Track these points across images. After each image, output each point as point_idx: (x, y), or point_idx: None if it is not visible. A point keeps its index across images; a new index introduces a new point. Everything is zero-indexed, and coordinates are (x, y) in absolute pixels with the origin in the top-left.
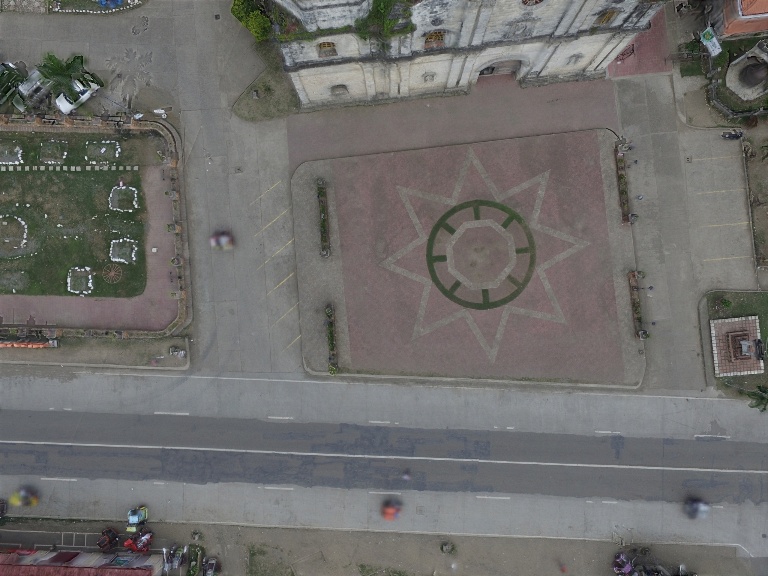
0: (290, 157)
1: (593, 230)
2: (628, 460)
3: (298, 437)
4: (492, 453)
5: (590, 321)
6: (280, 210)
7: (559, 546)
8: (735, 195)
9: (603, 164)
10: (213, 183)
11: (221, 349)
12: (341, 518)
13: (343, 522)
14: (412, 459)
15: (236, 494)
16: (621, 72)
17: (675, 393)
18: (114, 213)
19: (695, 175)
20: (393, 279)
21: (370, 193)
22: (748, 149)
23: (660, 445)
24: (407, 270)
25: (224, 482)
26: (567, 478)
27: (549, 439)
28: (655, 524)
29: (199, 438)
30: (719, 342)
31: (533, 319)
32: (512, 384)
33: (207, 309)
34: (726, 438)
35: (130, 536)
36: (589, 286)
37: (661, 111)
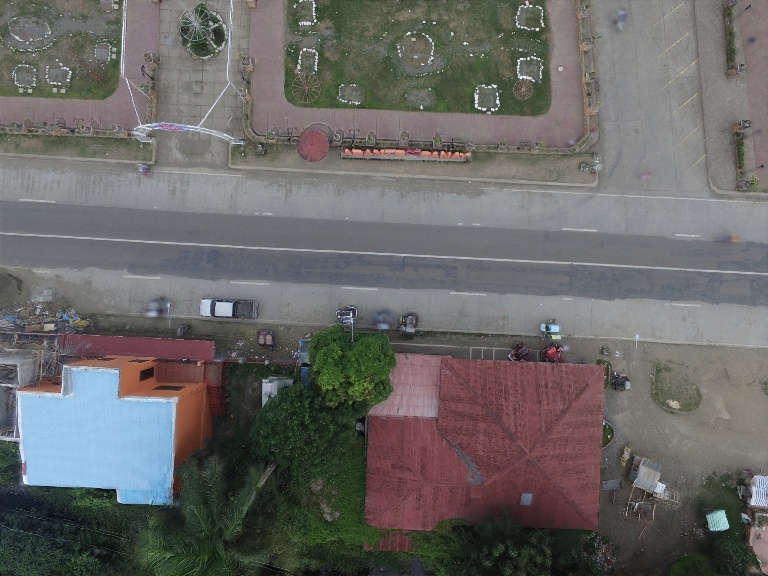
0: None
1: None
2: None
3: (705, 254)
4: None
5: None
6: (684, 31)
7: None
8: None
9: None
10: (616, 4)
11: (627, 167)
12: (747, 335)
13: (749, 339)
14: None
15: (644, 310)
16: None
17: None
18: (520, 32)
19: None
20: None
21: None
22: None
23: None
24: None
25: (632, 298)
26: None
27: None
28: None
29: (607, 254)
30: None
31: None
32: None
33: (612, 128)
34: None
35: (541, 350)
36: None
37: None
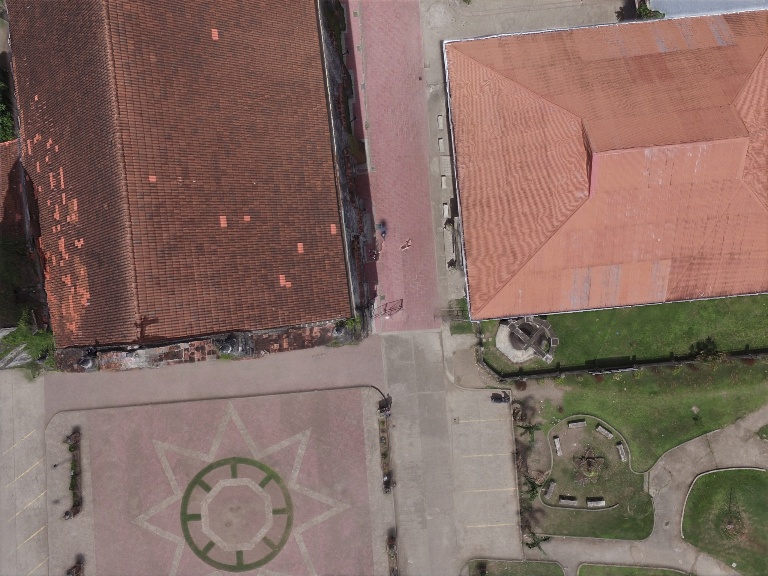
0: (46, 405)
1: (353, 493)
2: None
3: None
4: None
5: None
6: (33, 460)
7: None
8: (502, 459)
9: (366, 424)
10: None
11: None
12: None
13: None
14: None
15: None
16: (389, 327)
17: None
18: None
19: (462, 437)
20: (145, 537)
21: (125, 446)
22: (518, 411)
23: None
24: (160, 528)
25: None
26: None
27: None
28: None
29: None
30: None
31: None
32: None
33: None
34: None
35: None
36: (347, 551)
37: (429, 369)
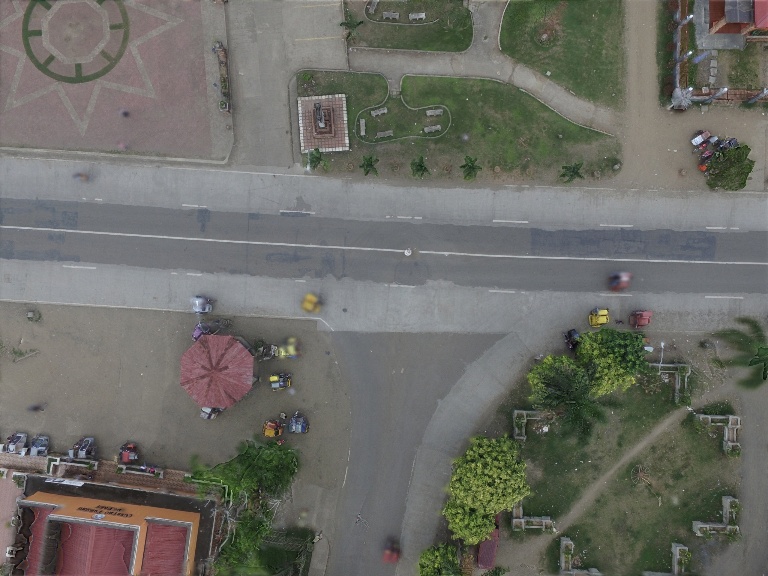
0: None
1: (186, 8)
2: (213, 233)
3: None
4: (79, 223)
5: (180, 96)
6: None
7: (144, 317)
8: None
9: None
10: None
11: None
12: None
13: None
14: (1, 228)
15: None
16: None
17: (263, 169)
18: None
19: None
20: None
21: None
22: None
23: (245, 219)
24: (2, 44)
25: None
26: (153, 250)
27: (136, 211)
28: (238, 297)
29: None
30: (305, 119)
31: (124, 93)
32: (102, 157)
33: None
34: (311, 214)
35: None
36: (180, 62)
37: None
